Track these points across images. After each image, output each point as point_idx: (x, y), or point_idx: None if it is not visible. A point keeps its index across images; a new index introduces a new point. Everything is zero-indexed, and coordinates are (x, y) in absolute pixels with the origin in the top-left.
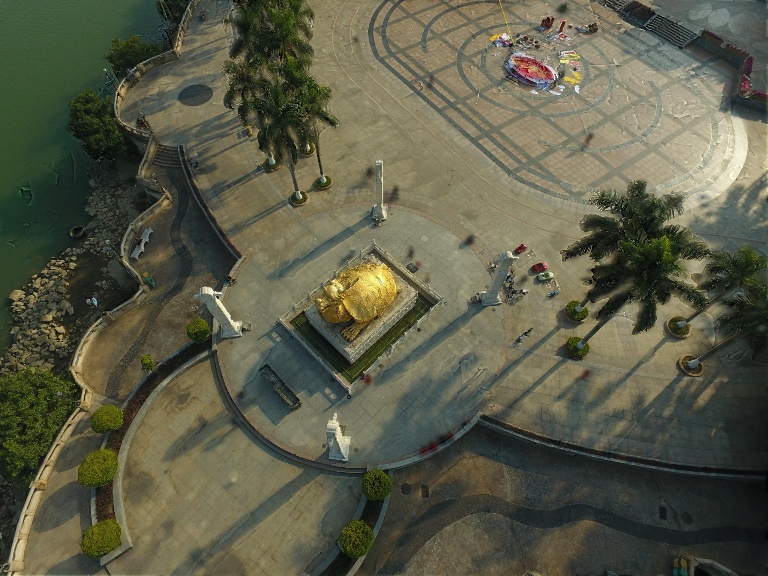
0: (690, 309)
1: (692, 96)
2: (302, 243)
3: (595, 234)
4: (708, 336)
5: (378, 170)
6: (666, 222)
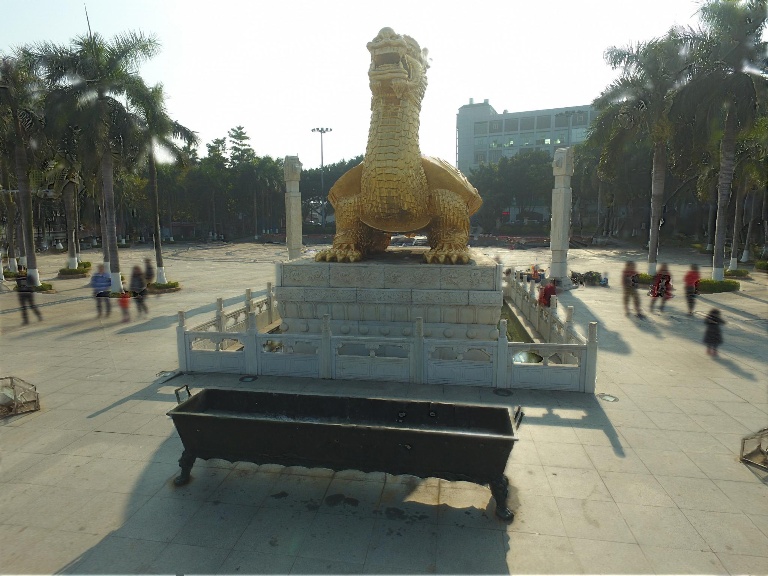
0: (710, 273)
1: (490, 250)
2: (161, 307)
3: (631, 94)
4: (758, 276)
5: (294, 164)
6: (588, 263)
